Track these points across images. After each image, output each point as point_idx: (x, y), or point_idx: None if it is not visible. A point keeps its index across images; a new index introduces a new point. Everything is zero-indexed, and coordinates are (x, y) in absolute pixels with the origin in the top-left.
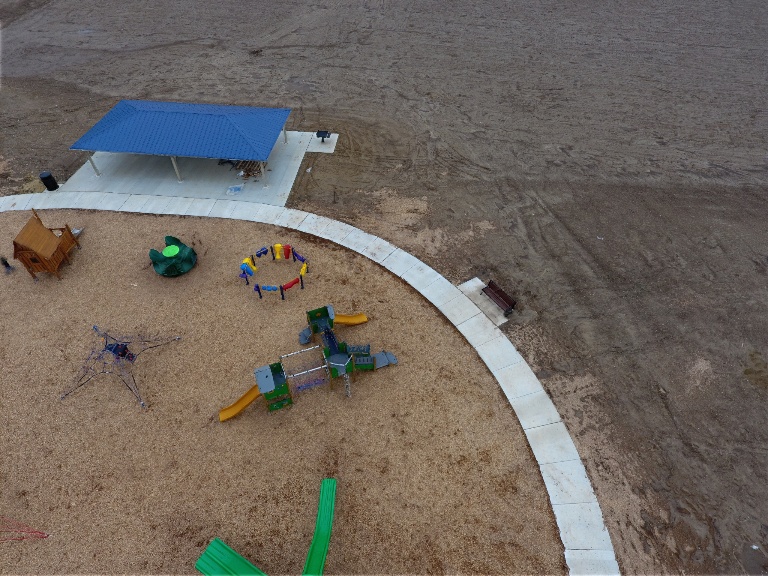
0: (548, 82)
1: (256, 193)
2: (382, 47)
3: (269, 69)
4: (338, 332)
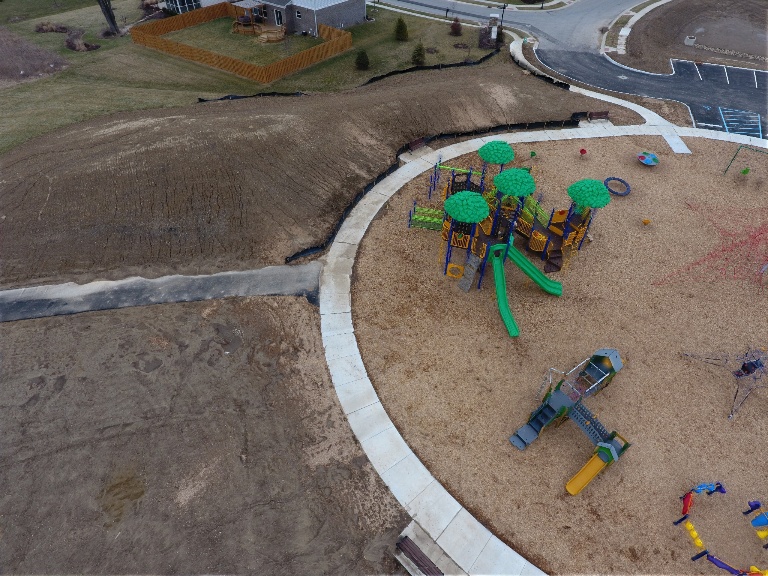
0: None
1: None
2: None
3: None
4: None
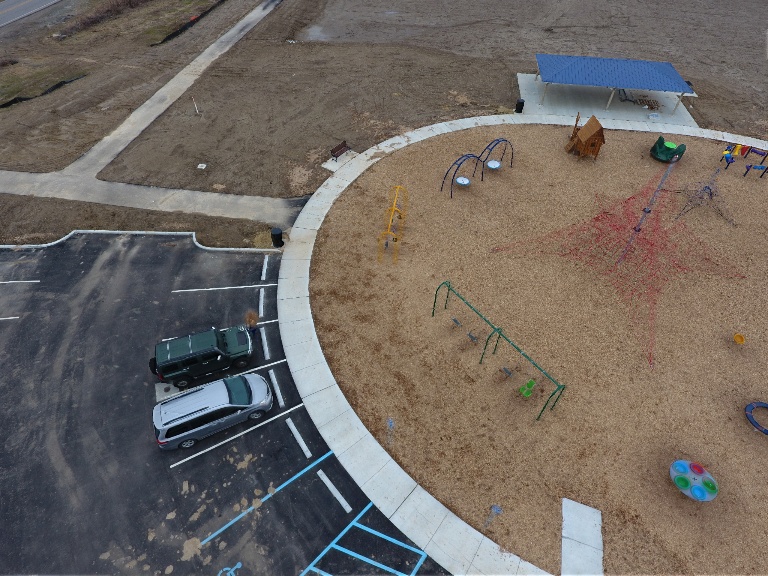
0: None
1: (670, 119)
2: (649, 28)
3: (574, 42)
4: None
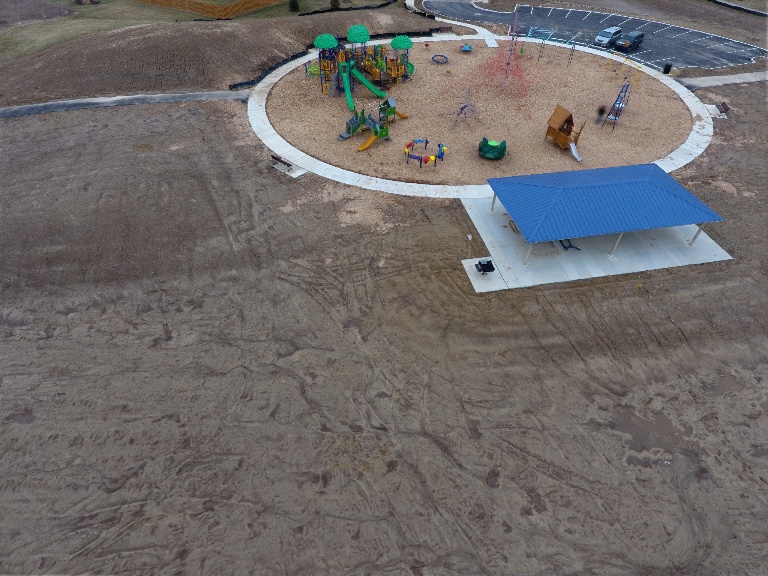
0: None
1: None
2: None
3: None
4: (373, 144)
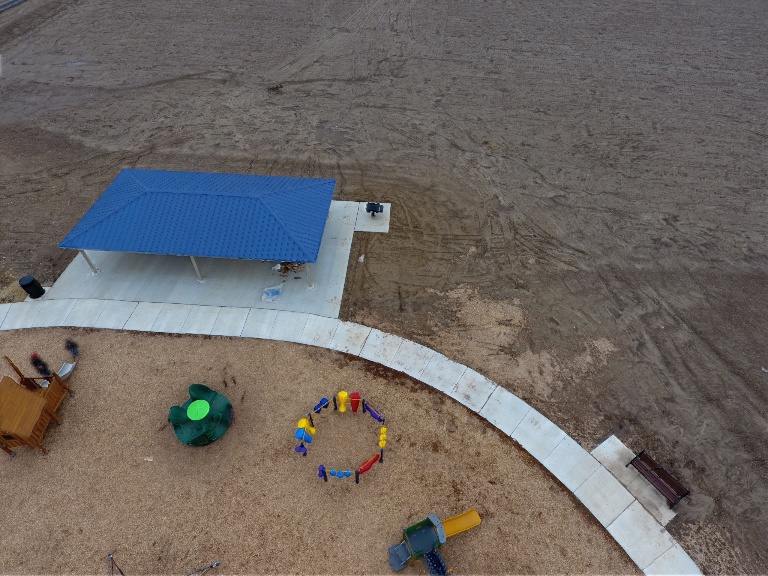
0: (622, 125)
1: (299, 297)
2: (420, 80)
3: (293, 111)
4: None
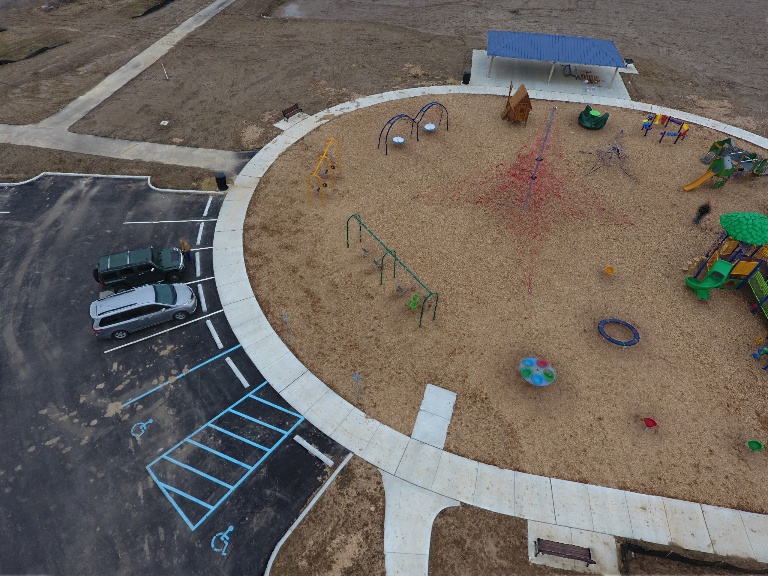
0: (763, 40)
1: (606, 92)
2: (612, 12)
3: (536, 23)
4: None
